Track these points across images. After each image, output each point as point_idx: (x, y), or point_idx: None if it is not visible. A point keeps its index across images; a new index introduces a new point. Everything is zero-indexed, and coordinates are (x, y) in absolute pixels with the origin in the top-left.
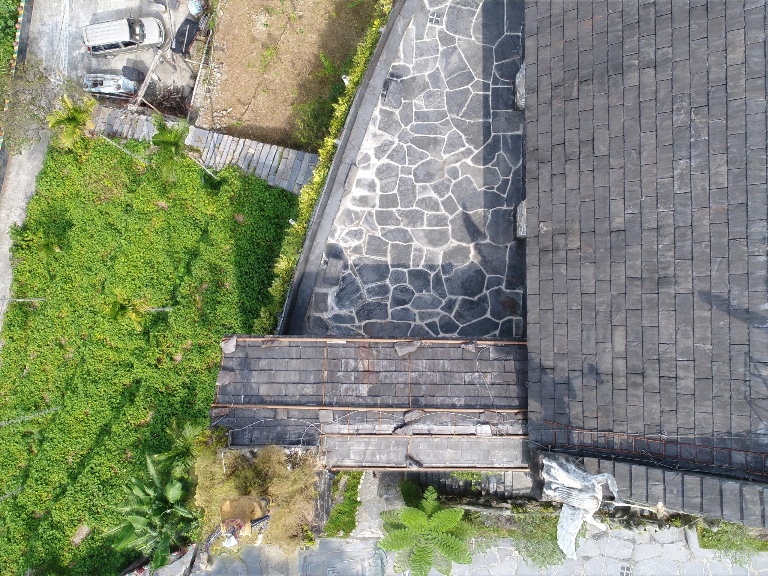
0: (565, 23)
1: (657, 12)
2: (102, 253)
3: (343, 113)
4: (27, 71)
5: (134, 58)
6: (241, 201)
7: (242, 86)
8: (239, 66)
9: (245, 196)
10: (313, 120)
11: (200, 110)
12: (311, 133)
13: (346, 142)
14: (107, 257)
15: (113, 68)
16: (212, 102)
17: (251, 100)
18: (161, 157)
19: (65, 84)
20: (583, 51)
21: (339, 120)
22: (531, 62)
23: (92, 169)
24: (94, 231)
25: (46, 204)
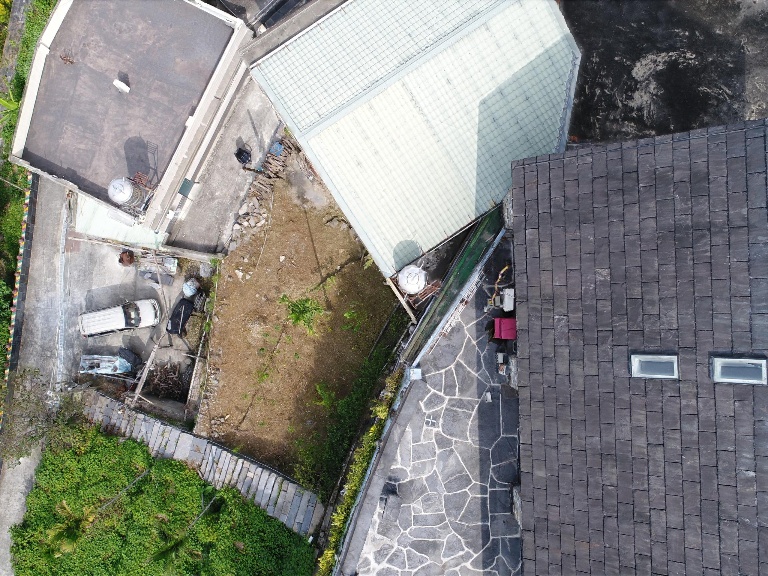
0: (562, 535)
1: (654, 569)
2: (103, 556)
3: (342, 521)
4: (24, 380)
5: (130, 334)
6: (241, 530)
7: (239, 393)
8: (236, 372)
9: (245, 524)
10: (311, 469)
11: (198, 417)
12: (310, 485)
13: (346, 553)
14: (108, 560)
15: (109, 345)
16: (209, 409)
17: (248, 408)
18: (160, 471)
19: (62, 401)
20: (581, 572)
21: (338, 529)
22: (529, 557)
23: (91, 470)
24: (95, 534)
25: (46, 498)
